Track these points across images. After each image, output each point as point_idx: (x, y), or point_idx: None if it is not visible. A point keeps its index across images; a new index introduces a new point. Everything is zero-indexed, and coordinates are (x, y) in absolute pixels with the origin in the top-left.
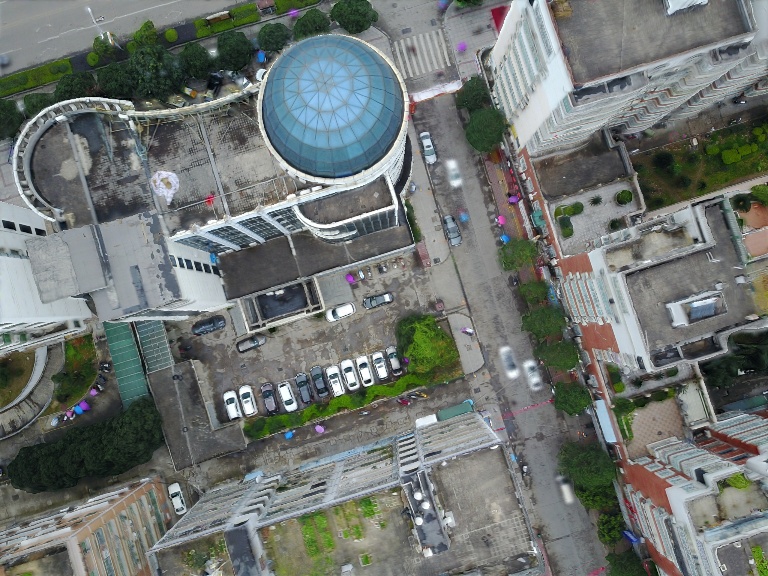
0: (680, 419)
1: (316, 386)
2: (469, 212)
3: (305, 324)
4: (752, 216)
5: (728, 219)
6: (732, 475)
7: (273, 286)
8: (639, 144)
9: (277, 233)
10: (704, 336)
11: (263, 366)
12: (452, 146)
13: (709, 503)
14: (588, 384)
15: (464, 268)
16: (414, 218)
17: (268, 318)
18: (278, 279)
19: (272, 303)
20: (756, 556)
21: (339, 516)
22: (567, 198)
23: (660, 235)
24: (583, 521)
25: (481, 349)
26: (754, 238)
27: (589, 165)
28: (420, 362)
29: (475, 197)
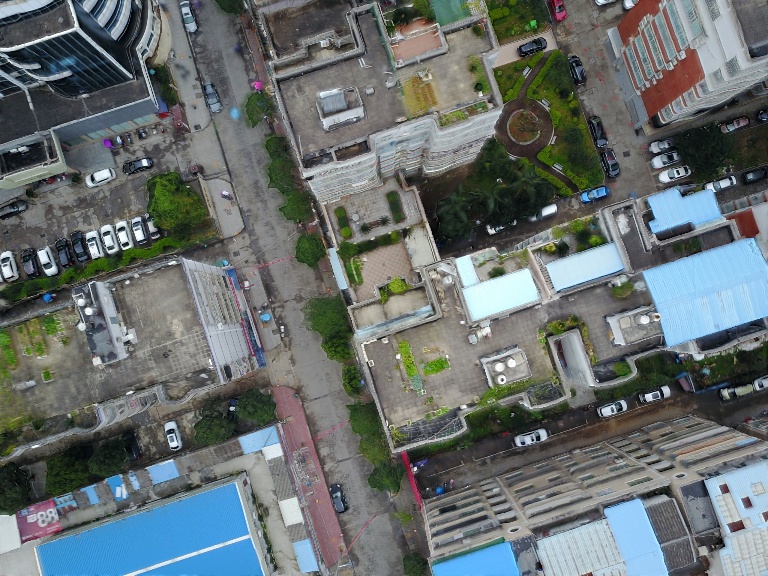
0: (409, 264)
1: (74, 250)
2: (230, 80)
3: (67, 191)
4: (421, 32)
5: (379, 26)
6: (392, 280)
7: (11, 140)
8: (385, 4)
9: (13, 87)
10: (357, 141)
11: (26, 233)
12: (214, 15)
13: (376, 311)
14: (327, 235)
15: (225, 135)
16: (169, 82)
17: (8, 173)
18: (17, 134)
19: (19, 162)
20: (403, 351)
21: (23, 334)
22: (299, 50)
23: (331, 52)
24: (341, 381)
25: (241, 214)
26: (406, 45)
27: (321, 18)
28: (165, 218)
29: (236, 65)
